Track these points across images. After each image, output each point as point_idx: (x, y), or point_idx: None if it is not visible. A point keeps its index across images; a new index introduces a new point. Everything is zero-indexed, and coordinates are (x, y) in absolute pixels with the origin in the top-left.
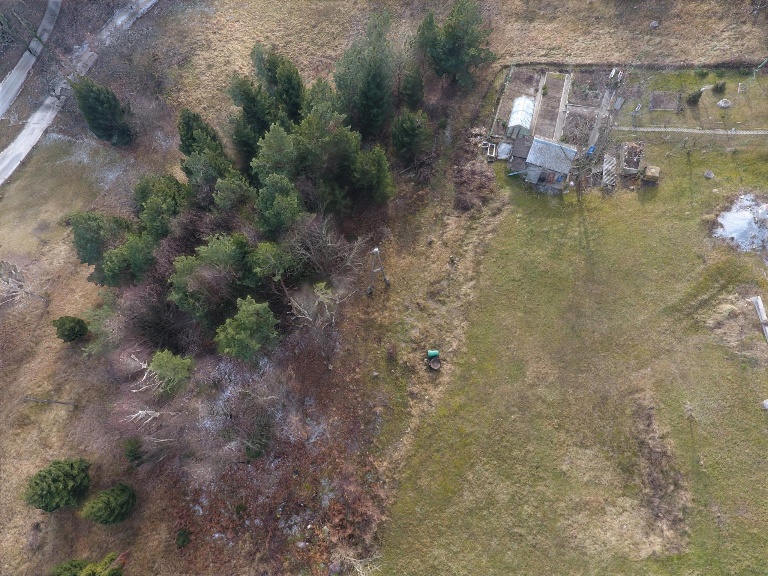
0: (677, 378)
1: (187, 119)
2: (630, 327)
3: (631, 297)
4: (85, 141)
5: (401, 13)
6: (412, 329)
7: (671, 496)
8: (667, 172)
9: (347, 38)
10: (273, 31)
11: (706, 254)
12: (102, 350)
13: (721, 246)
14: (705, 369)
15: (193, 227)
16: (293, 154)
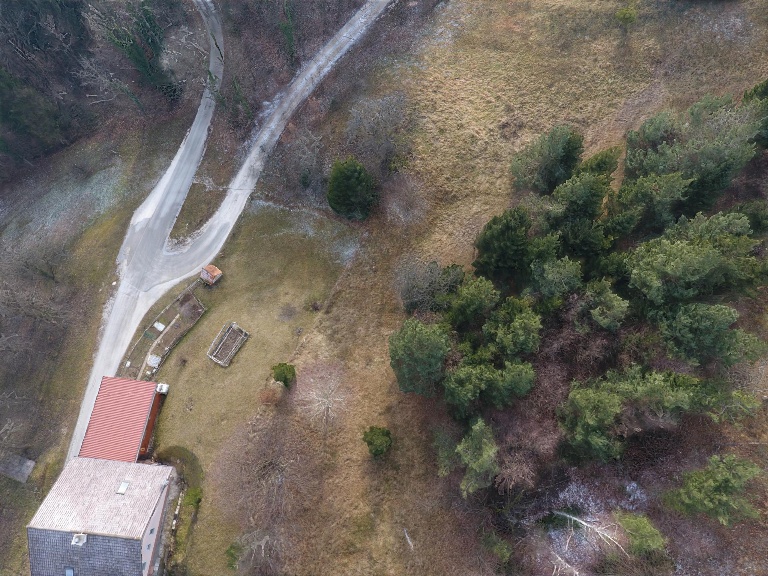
0: None
1: (525, 218)
2: None
3: None
4: (304, 211)
5: (651, 72)
6: None
7: None
8: None
9: (592, 99)
10: (503, 90)
11: None
12: (477, 486)
13: None
14: None
15: None
16: (704, 273)
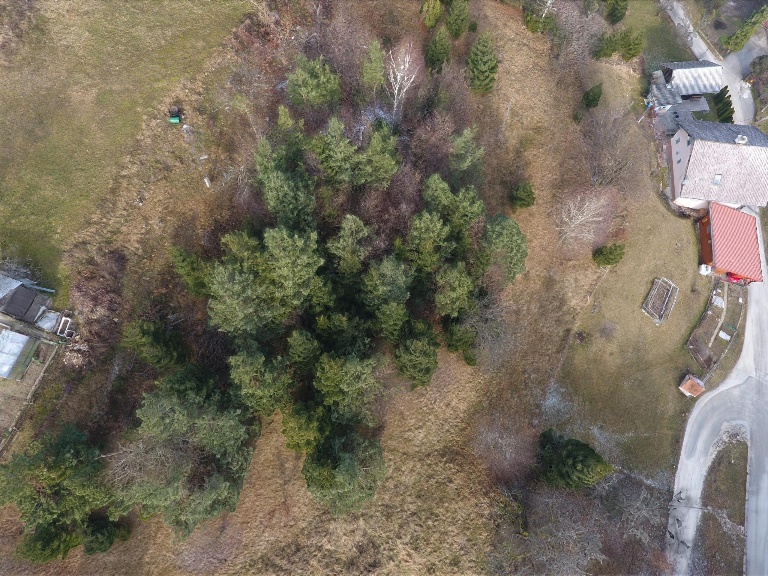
0: None
1: None
2: None
3: None
4: None
5: None
6: None
7: (12, 5)
8: None
9: None
10: None
11: None
12: None
13: None
14: None
15: None
16: None
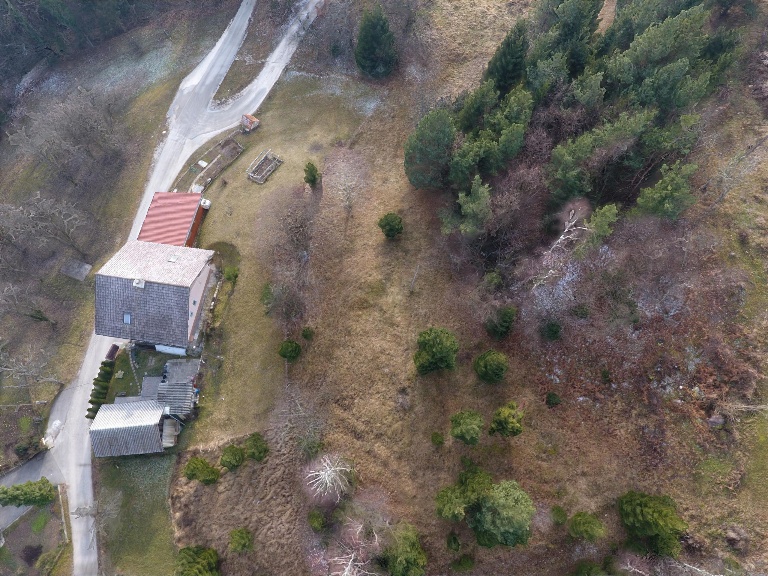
0: None
1: (523, 31)
2: None
3: None
4: (332, 76)
5: None
6: (755, 218)
7: None
8: None
9: None
10: None
11: None
12: None
13: None
14: None
15: (551, 122)
16: (667, 51)
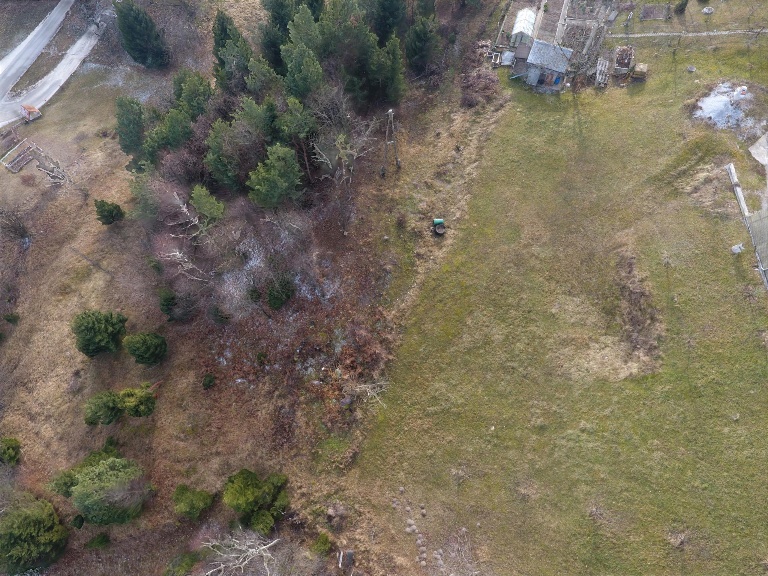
0: (657, 234)
1: (222, 20)
2: (616, 195)
3: (618, 172)
4: (120, 68)
5: None
6: (420, 203)
7: (648, 329)
8: (654, 70)
9: None
10: None
11: (686, 132)
12: (142, 214)
13: (700, 125)
14: (682, 226)
15: (226, 109)
16: (318, 38)
